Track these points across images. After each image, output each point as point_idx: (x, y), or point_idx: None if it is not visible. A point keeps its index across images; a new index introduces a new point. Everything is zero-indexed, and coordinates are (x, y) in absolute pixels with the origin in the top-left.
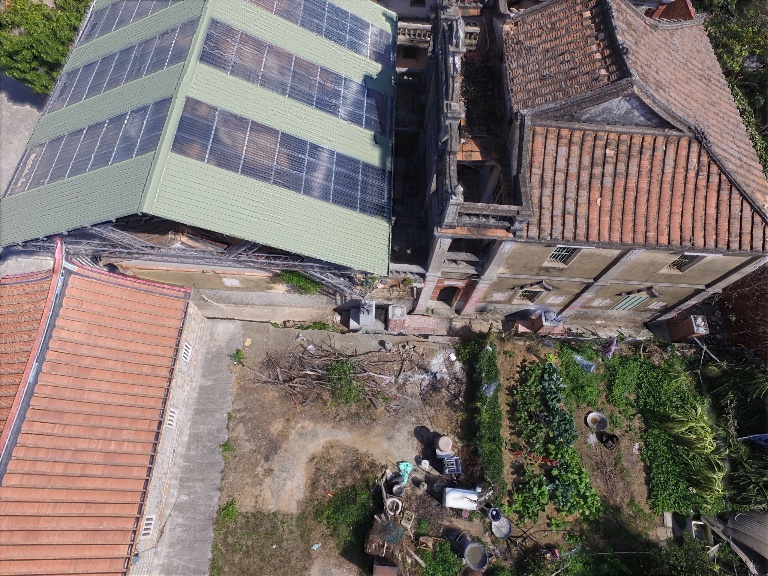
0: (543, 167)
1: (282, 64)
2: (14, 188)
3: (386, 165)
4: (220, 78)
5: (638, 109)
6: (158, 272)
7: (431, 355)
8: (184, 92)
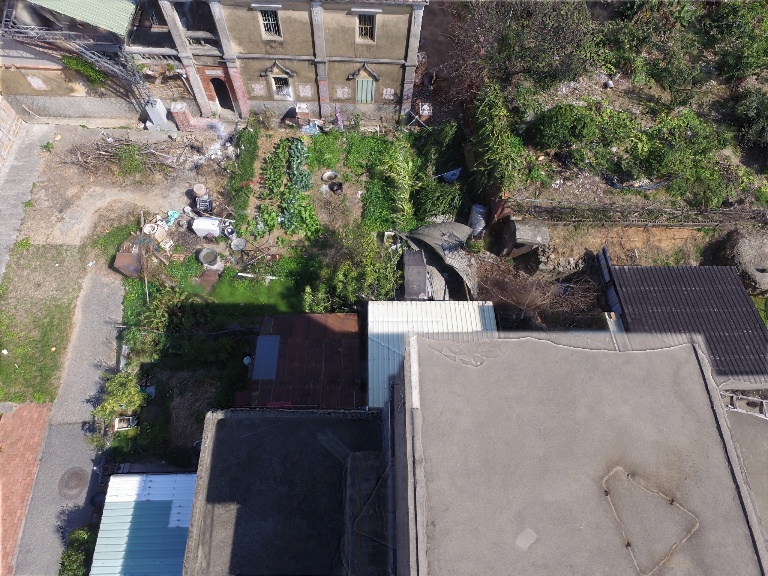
0: None
1: None
2: None
3: None
4: None
5: None
6: None
7: (210, 143)
8: None
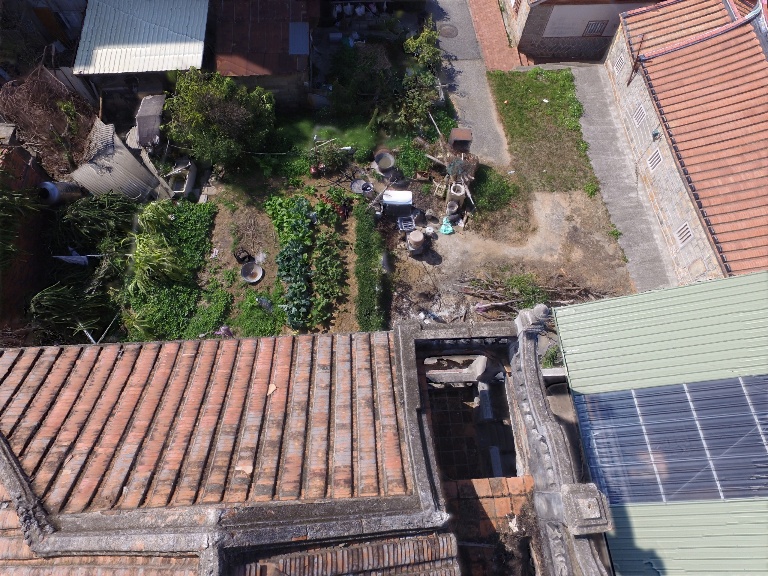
0: (376, 429)
1: None
2: None
3: (613, 516)
4: None
5: None
6: None
7: None
8: None
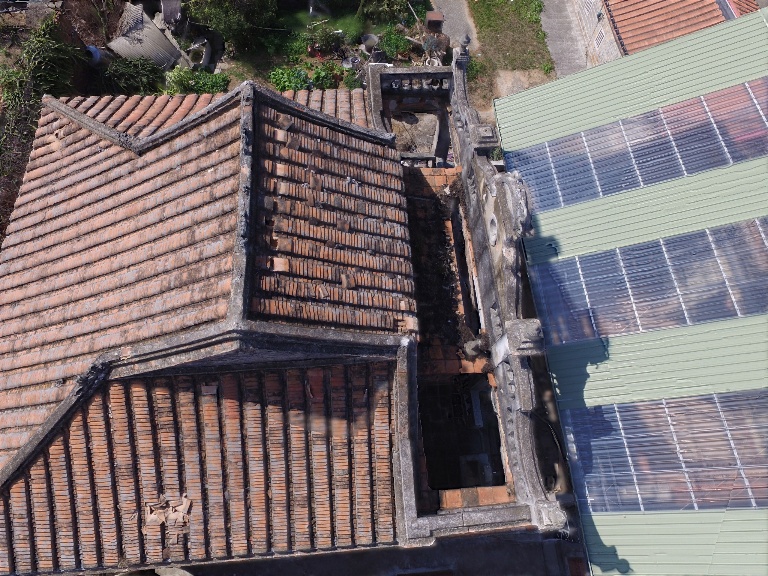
0: None
1: (748, 283)
2: None
3: None
4: None
5: None
6: None
7: None
8: None
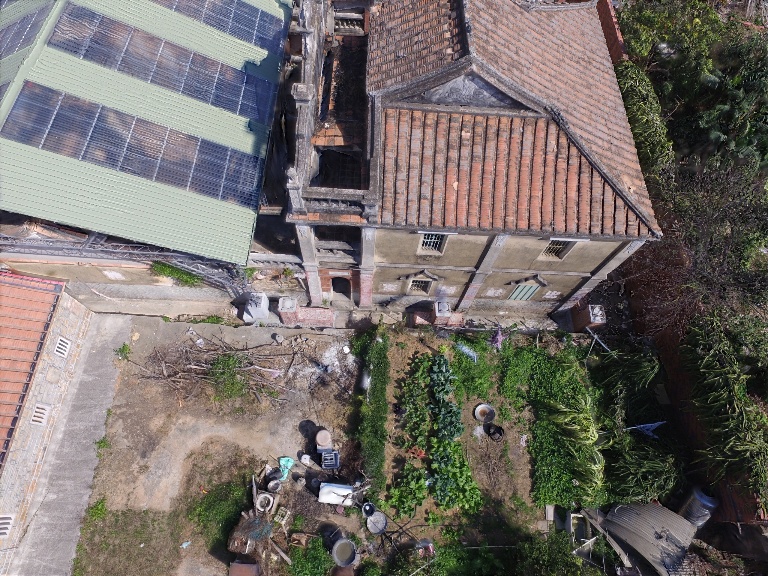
0: (397, 151)
1: (148, 49)
2: None
3: (260, 152)
4: (70, 62)
5: (486, 89)
6: (34, 265)
7: (324, 348)
8: (23, 76)
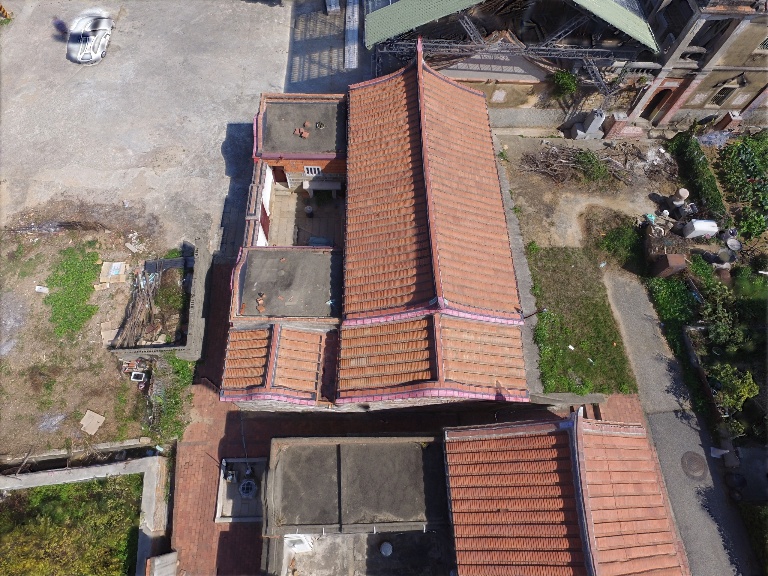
0: None
1: None
2: (376, 6)
3: None
4: None
5: None
6: None
7: (645, 150)
8: None
